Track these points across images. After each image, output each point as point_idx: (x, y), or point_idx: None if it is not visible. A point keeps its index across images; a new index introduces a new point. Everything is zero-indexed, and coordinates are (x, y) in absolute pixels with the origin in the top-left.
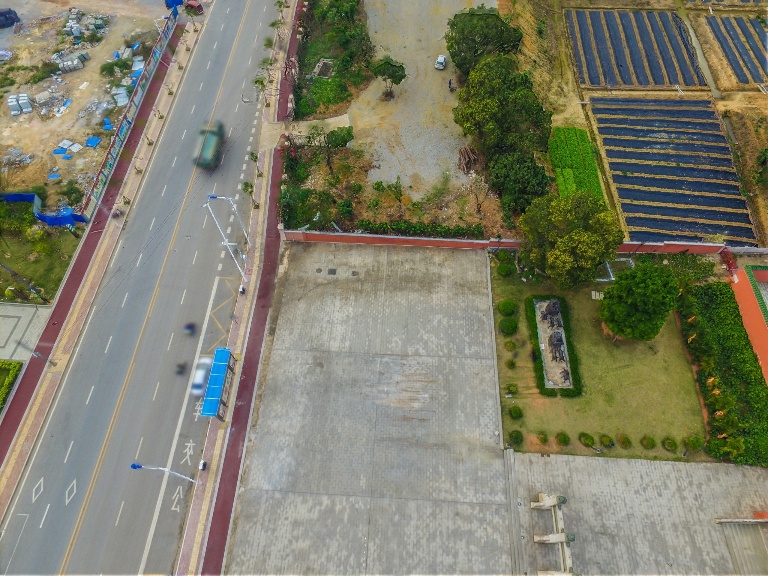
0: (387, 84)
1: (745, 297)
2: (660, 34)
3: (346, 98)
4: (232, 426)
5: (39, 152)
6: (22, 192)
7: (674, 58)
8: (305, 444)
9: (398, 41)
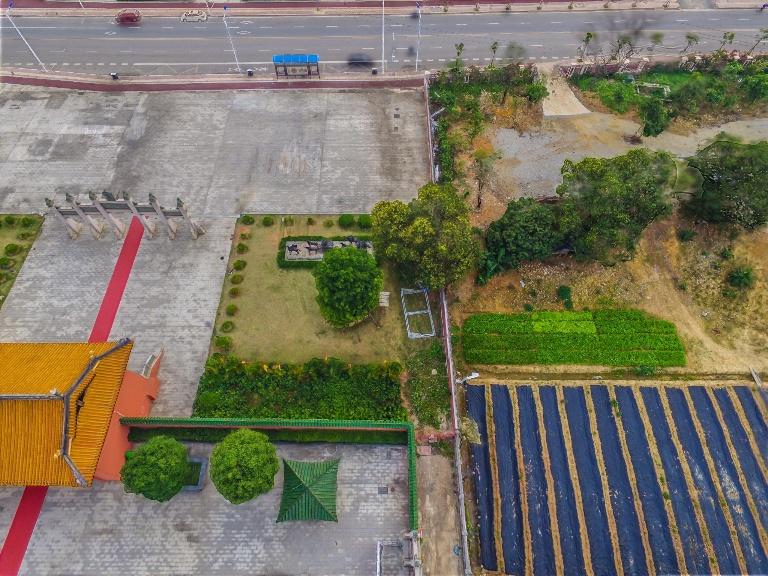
0: (641, 128)
1: None
2: None
3: (614, 109)
4: (274, 82)
5: None
6: None
7: None
8: (259, 114)
9: None
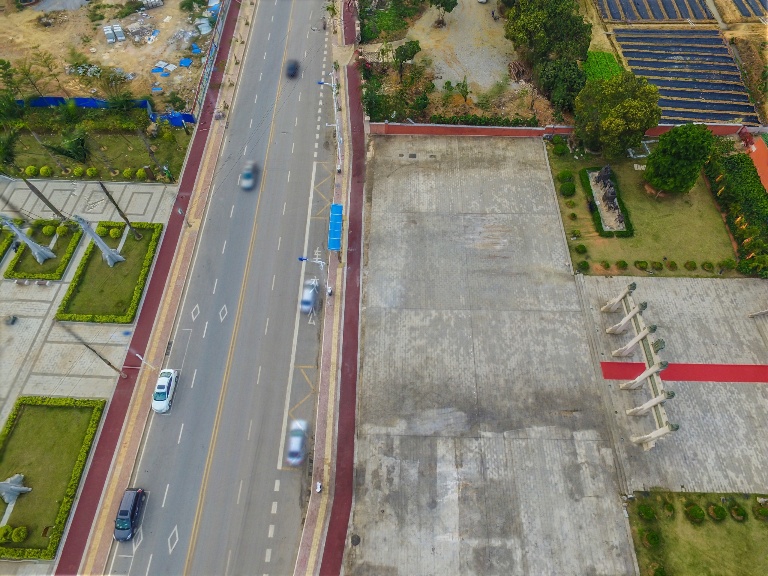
0: (440, 12)
1: (762, 160)
2: None
3: (403, 26)
4: (348, 266)
5: (139, 71)
6: (134, 99)
7: None
8: (411, 276)
9: None
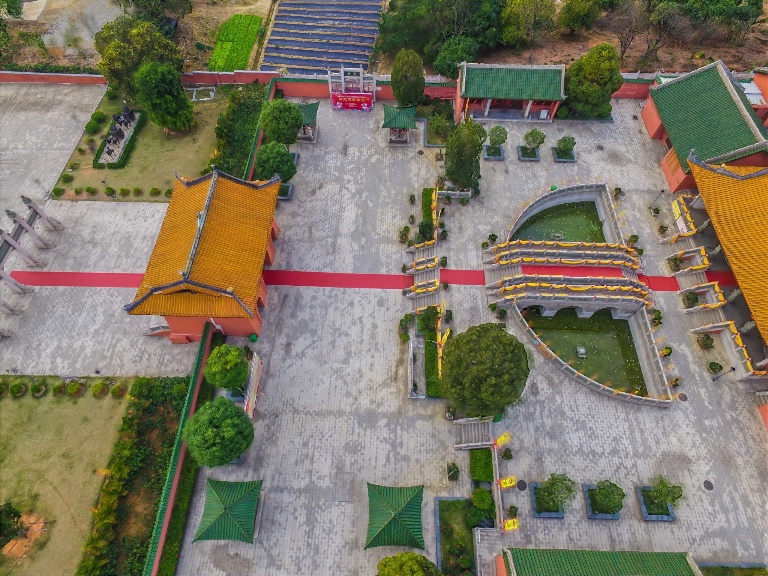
0: None
1: None
2: None
3: None
4: None
5: None
6: None
7: None
8: None
9: None
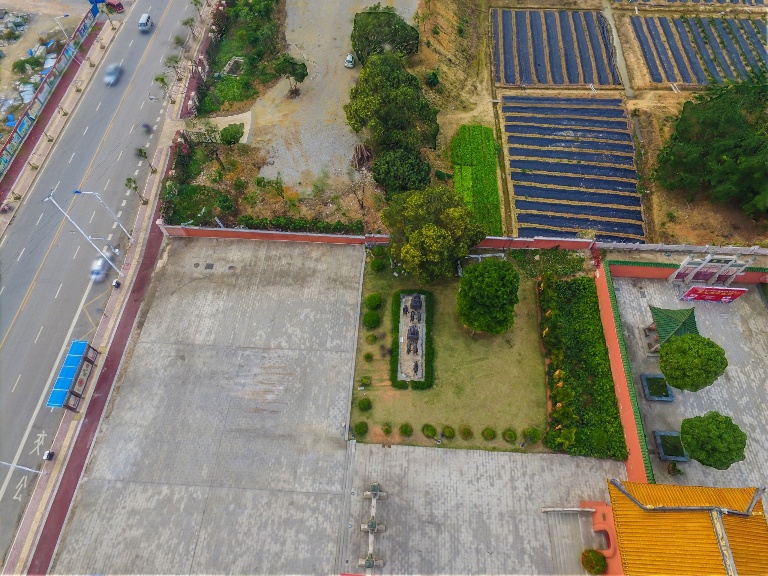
0: (291, 82)
1: (602, 291)
2: (582, 33)
3: (252, 96)
4: (86, 417)
5: None
6: None
7: (592, 57)
8: (154, 435)
9: (313, 40)
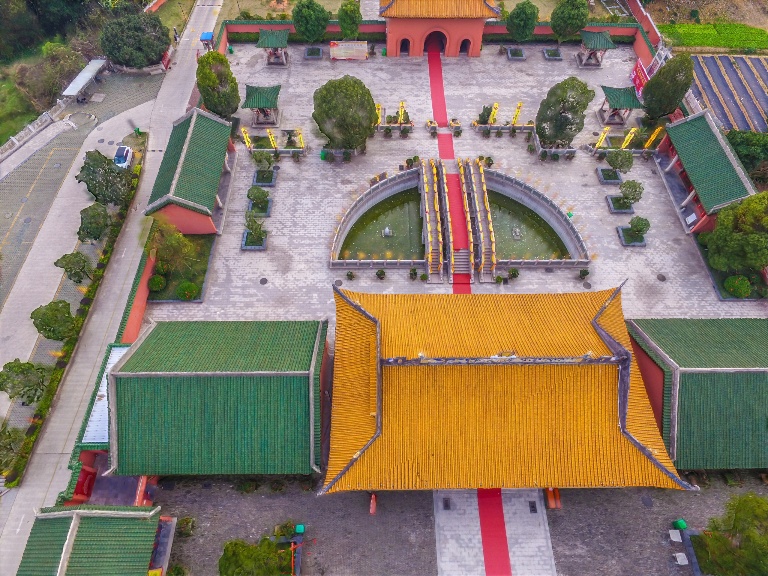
0: None
1: None
2: None
3: None
4: None
5: None
6: None
7: None
8: None
9: None
